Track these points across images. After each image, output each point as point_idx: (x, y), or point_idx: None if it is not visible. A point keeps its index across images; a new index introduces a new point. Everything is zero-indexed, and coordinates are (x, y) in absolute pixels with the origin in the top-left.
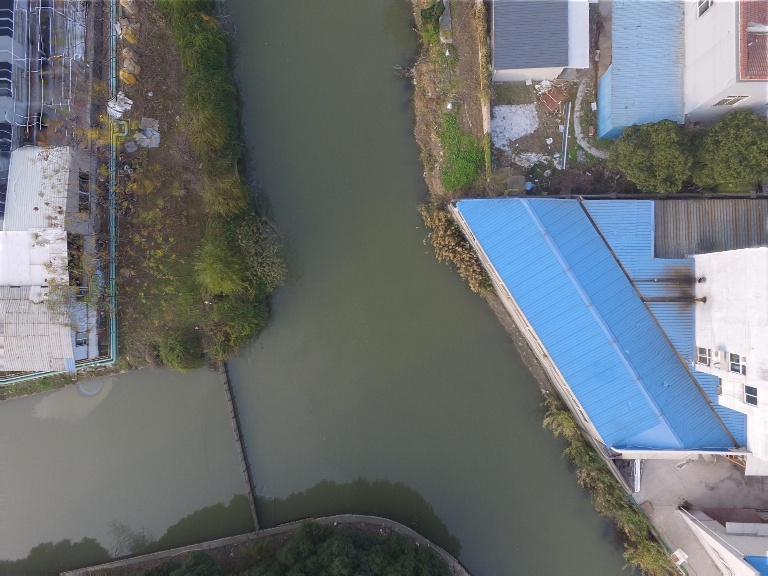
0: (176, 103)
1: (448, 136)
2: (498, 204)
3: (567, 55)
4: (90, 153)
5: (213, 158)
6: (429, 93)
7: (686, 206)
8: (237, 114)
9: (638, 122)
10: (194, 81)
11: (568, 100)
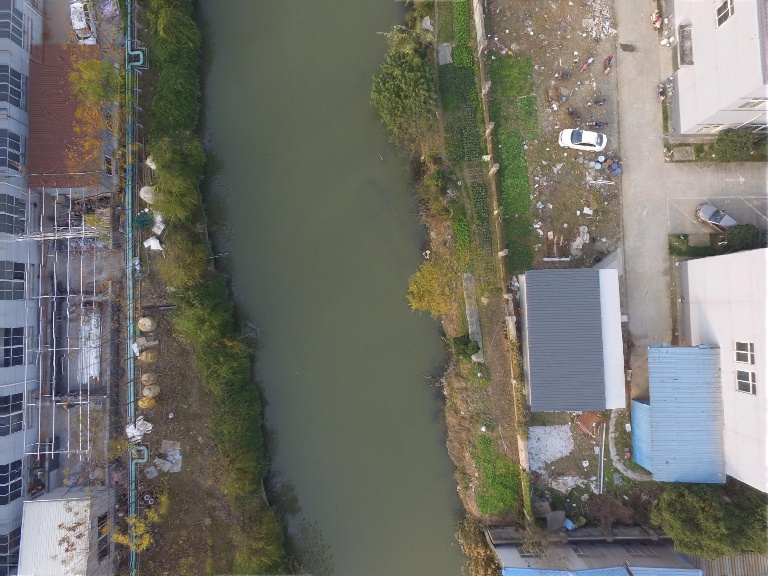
0: (198, 423)
1: (483, 459)
2: (545, 575)
3: (604, 399)
4: (108, 489)
5: (241, 496)
6: (462, 412)
7: (730, 559)
8: (262, 428)
9: (680, 478)
10: (219, 415)
11: (602, 422)
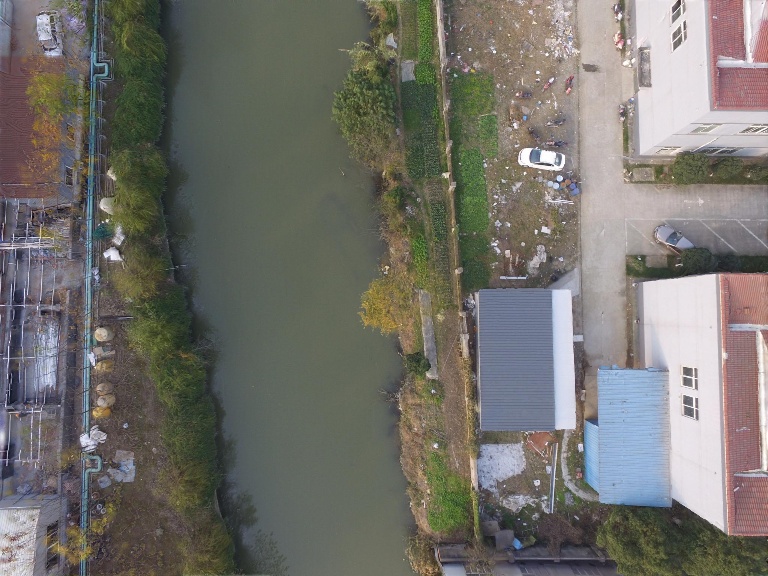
0: (153, 434)
1: (435, 476)
2: None
3: (554, 420)
4: (60, 498)
5: (191, 508)
6: (415, 428)
7: None
8: (217, 439)
9: (626, 501)
10: (172, 426)
11: (555, 441)
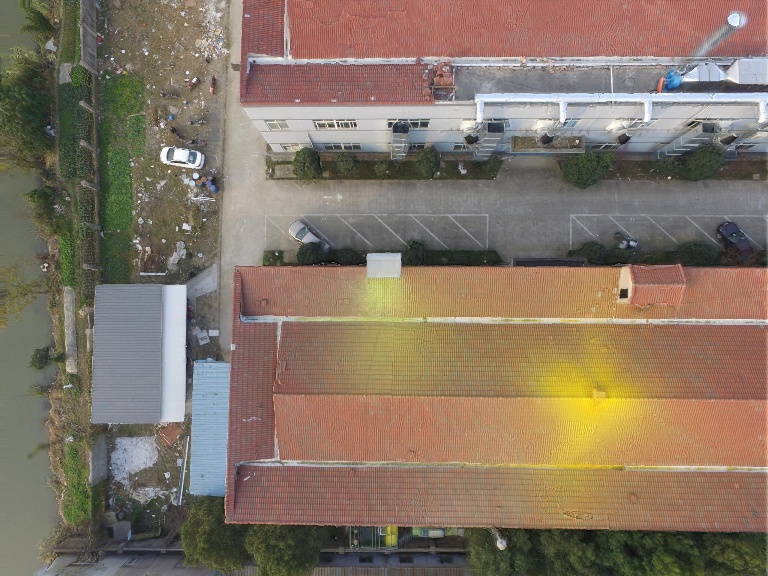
0: None
1: (69, 469)
2: None
3: (158, 413)
4: None
5: None
6: (56, 421)
7: None
8: None
9: (213, 492)
10: None
11: (186, 434)
